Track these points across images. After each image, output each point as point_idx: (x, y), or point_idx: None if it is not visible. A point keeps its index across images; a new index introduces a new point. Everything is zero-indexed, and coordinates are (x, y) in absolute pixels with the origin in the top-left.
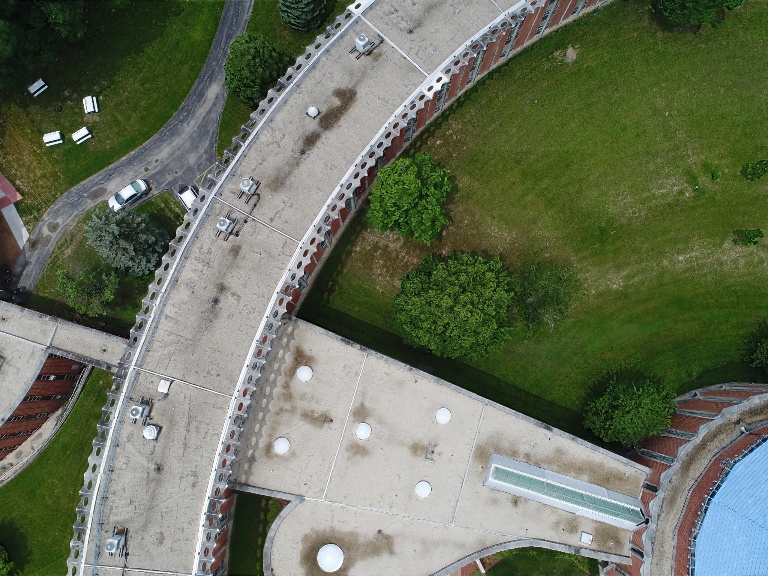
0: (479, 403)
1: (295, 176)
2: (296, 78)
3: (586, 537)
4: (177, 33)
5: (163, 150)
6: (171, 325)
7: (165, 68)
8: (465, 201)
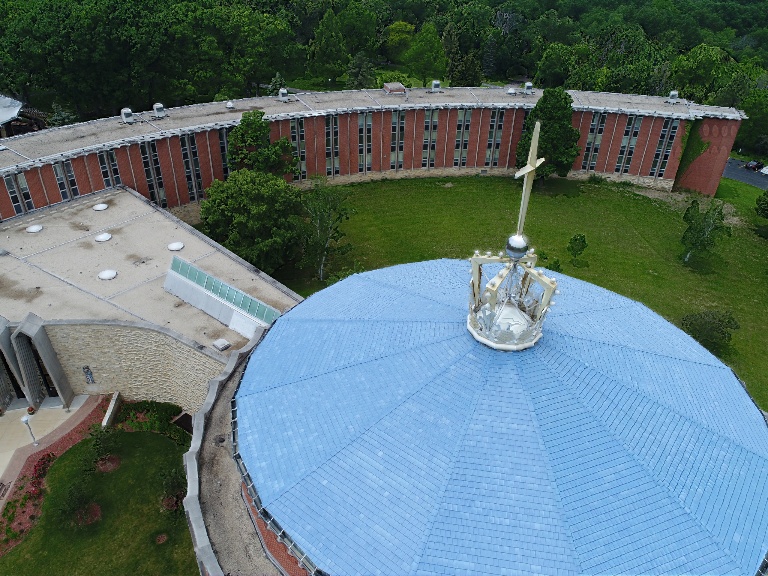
0: (213, 249)
1: (193, 118)
2: None
3: (221, 341)
4: None
5: None
6: (42, 137)
7: None
8: None
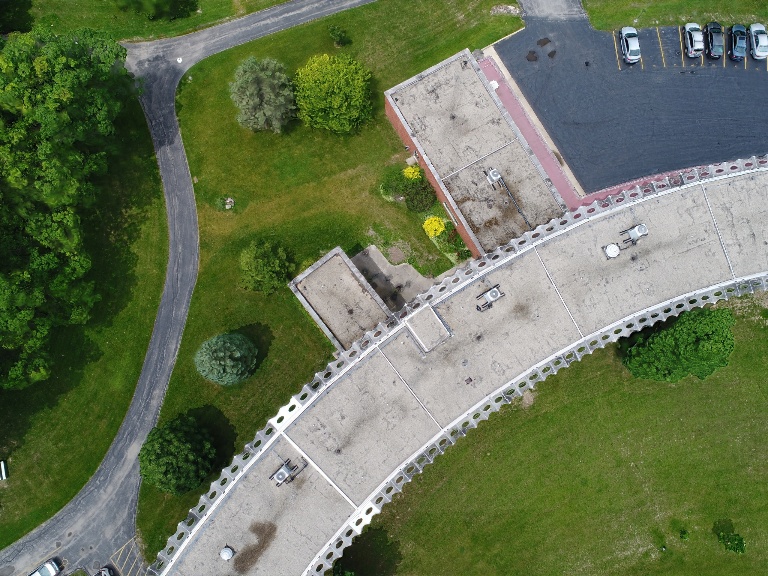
0: None
1: None
2: (209, 510)
3: None
4: (95, 382)
5: (77, 521)
6: None
7: (81, 424)
8: (409, 570)
